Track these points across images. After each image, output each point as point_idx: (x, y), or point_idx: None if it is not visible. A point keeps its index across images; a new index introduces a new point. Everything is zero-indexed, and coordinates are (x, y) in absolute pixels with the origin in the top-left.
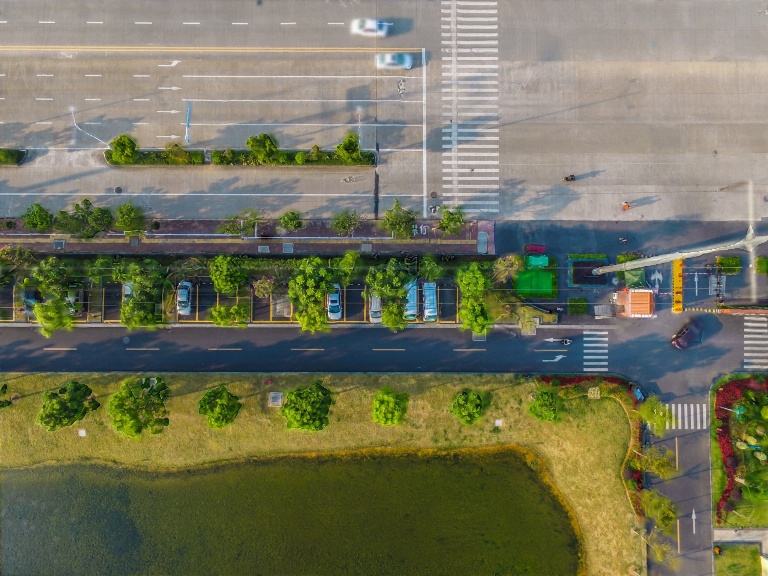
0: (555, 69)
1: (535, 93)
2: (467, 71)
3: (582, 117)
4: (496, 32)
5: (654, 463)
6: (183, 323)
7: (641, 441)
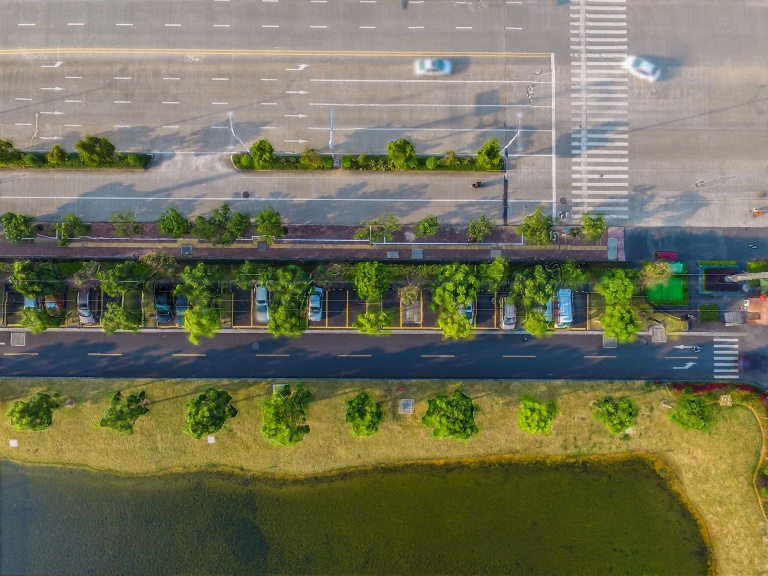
0: (684, 75)
1: (664, 99)
2: (596, 76)
3: (712, 123)
4: (625, 37)
5: None
6: (313, 329)
7: None
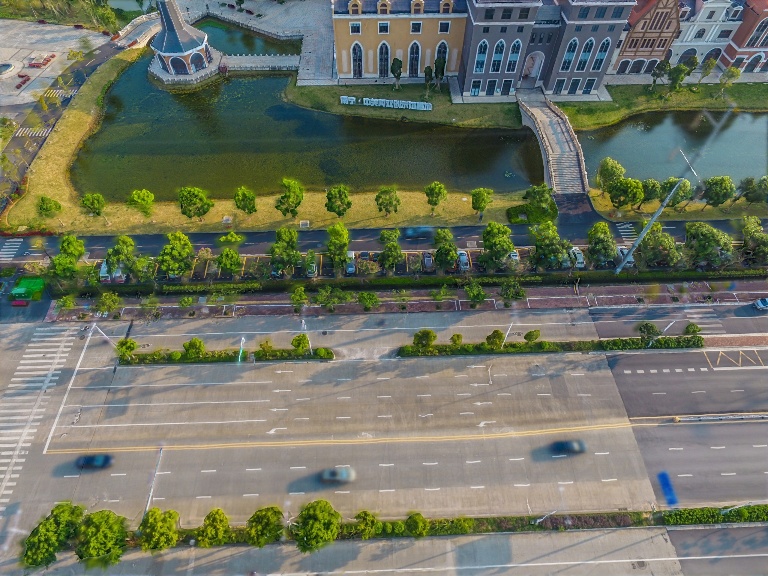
0: None
1: None
2: (13, 434)
3: None
4: None
5: (3, 197)
6: None
7: (5, 207)
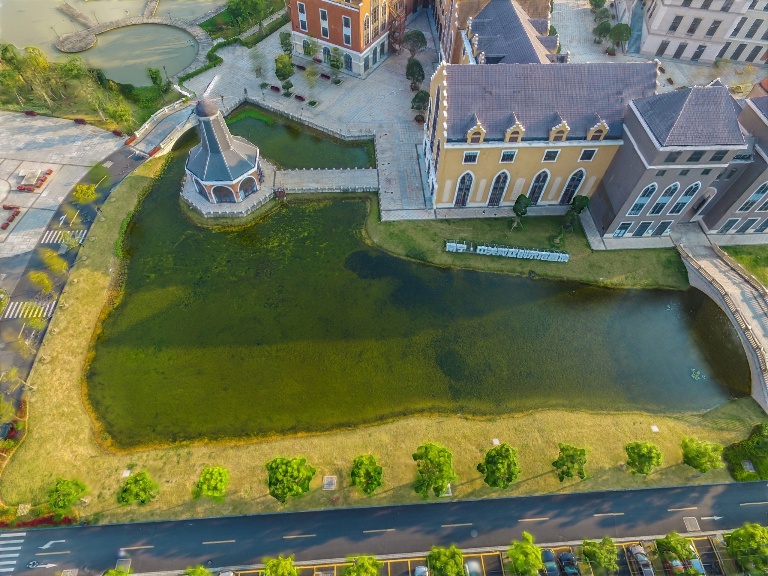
0: None
1: None
2: None
3: None
4: None
5: None
6: (422, 557)
7: None
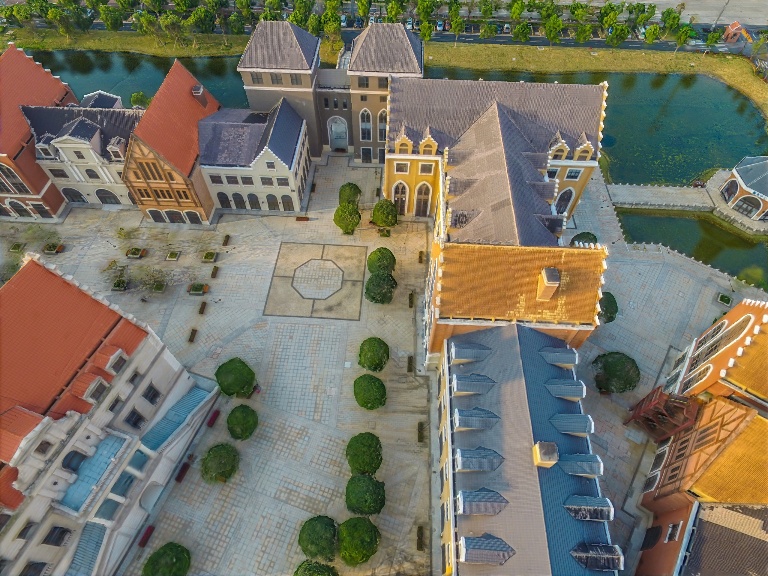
0: None
1: None
2: None
3: (685, 4)
4: None
5: None
6: None
7: None
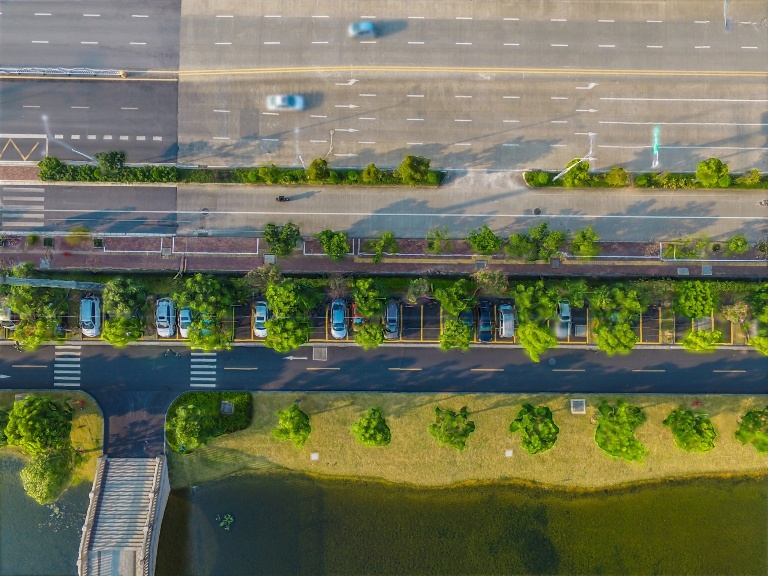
0: None
1: None
2: None
3: None
4: None
5: None
6: None
7: None
